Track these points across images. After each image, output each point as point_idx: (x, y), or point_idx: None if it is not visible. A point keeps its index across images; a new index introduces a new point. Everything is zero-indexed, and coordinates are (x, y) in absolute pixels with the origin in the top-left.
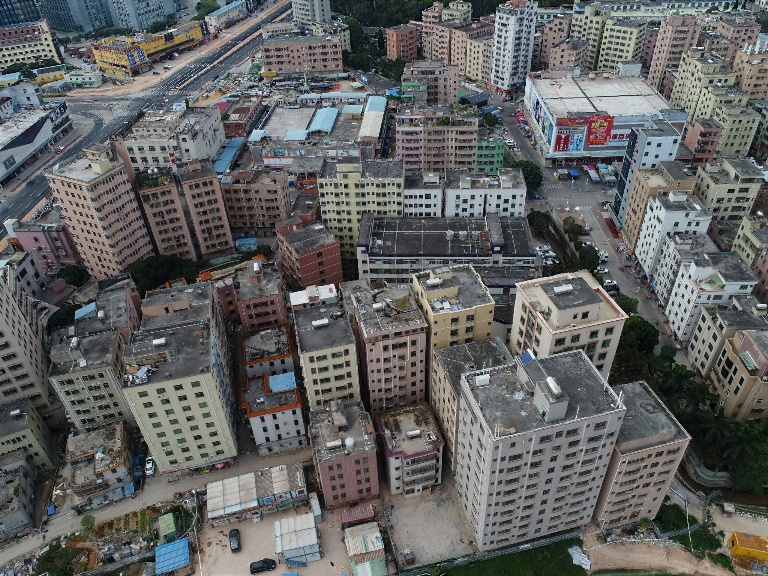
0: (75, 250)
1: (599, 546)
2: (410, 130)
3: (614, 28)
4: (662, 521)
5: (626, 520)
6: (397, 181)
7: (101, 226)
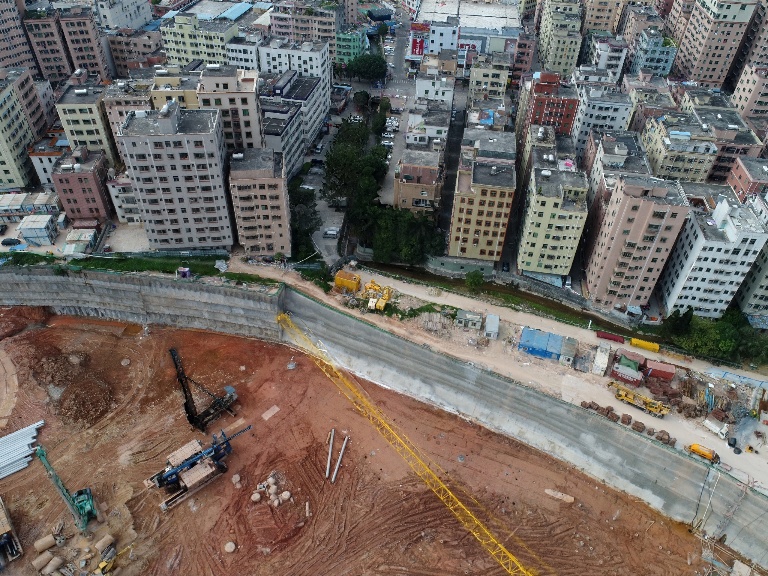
0: None
1: (240, 263)
2: (281, 16)
3: None
4: (298, 261)
5: (265, 251)
6: (220, 35)
7: None
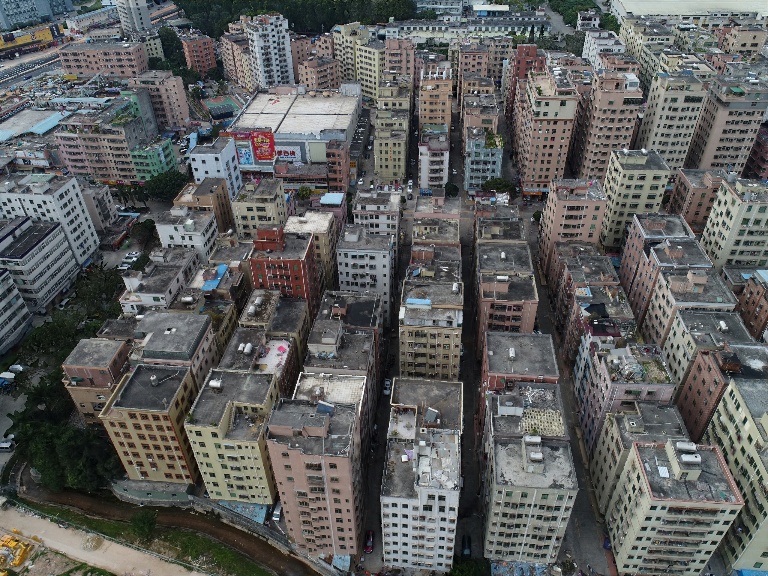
0: None
1: None
2: (66, 136)
3: (362, 48)
4: None
5: None
6: None
7: None
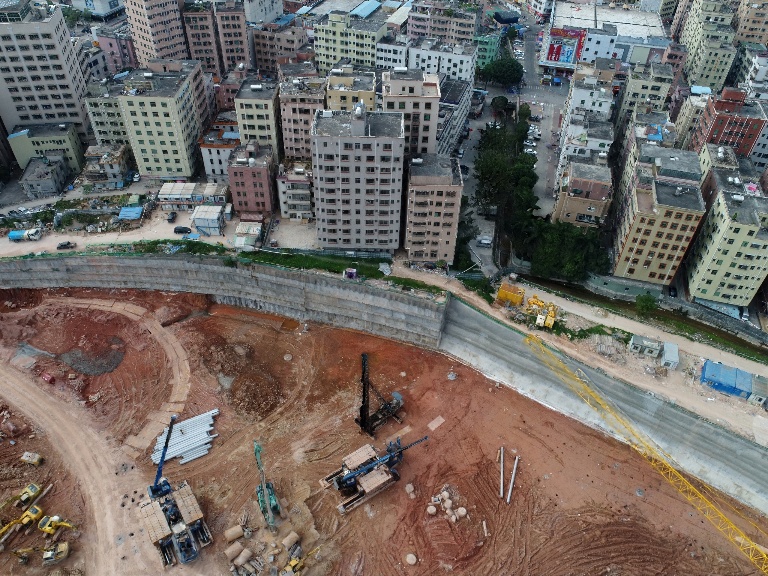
0: (137, 59)
1: (403, 267)
2: (419, 16)
3: None
4: (458, 270)
5: (428, 257)
6: (372, 34)
7: (151, 32)
